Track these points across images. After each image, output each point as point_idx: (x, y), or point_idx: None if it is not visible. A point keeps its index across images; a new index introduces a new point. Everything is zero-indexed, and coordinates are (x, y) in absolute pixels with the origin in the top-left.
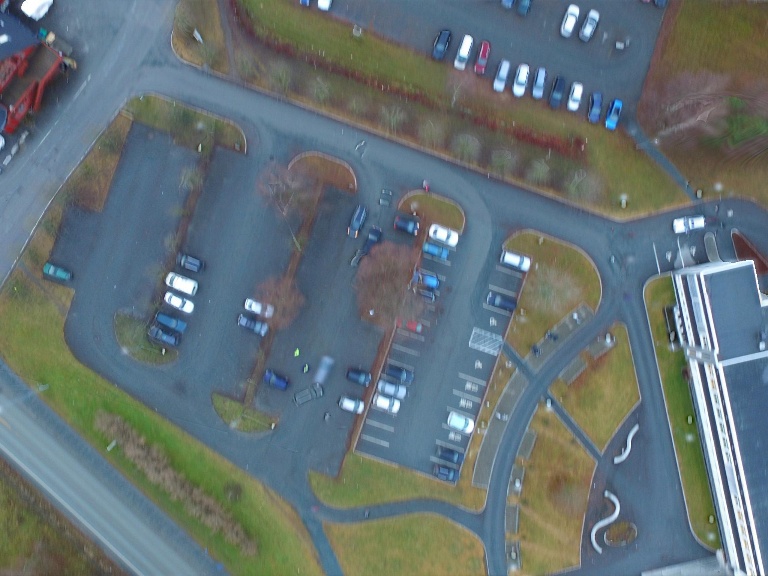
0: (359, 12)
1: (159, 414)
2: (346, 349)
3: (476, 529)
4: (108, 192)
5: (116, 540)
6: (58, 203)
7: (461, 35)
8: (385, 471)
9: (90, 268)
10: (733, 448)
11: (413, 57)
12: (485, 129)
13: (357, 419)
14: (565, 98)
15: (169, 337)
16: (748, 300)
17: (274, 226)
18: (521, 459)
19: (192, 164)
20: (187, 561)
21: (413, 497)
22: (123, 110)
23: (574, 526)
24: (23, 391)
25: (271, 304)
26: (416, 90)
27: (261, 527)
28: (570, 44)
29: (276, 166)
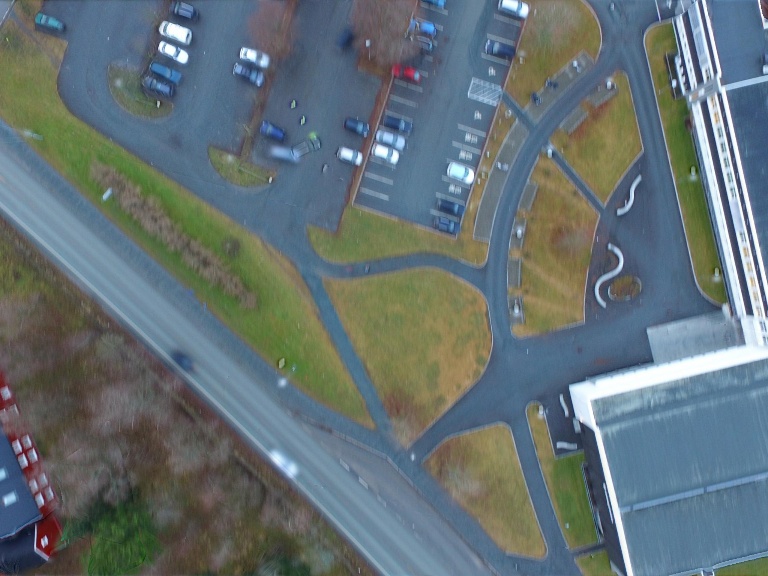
0: None
1: (155, 168)
2: (343, 100)
3: (478, 283)
4: None
5: (113, 295)
6: None
7: None
8: (385, 225)
9: (82, 19)
10: (738, 175)
11: None
12: None
13: (355, 172)
14: None
15: (164, 86)
16: (751, 23)
17: None
18: (522, 212)
19: None
20: (186, 316)
21: (414, 251)
22: None
23: (577, 280)
24: (17, 144)
25: (266, 53)
26: None
27: (260, 283)
28: None
29: None
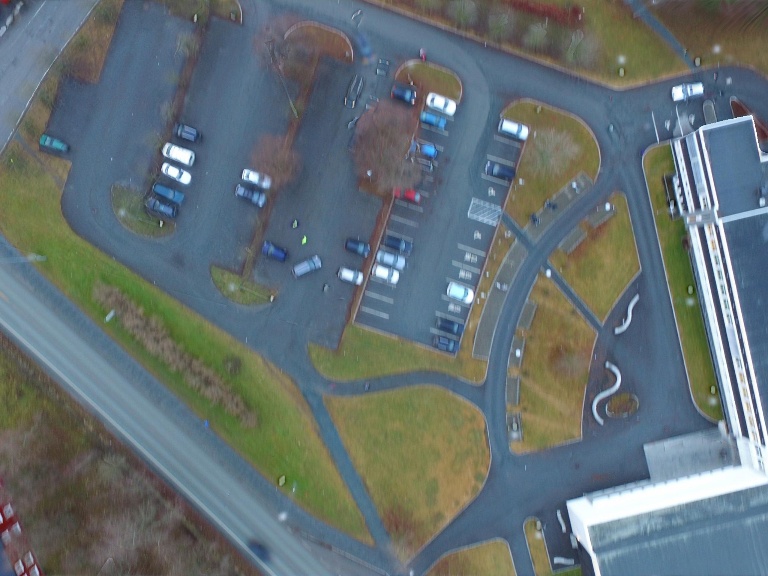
0: None
1: (157, 287)
2: (344, 220)
3: (477, 401)
4: (104, 63)
5: (116, 413)
6: (54, 74)
7: None
8: (385, 343)
9: (86, 140)
10: (734, 306)
11: None
12: None
13: (356, 291)
14: None
15: (166, 207)
16: (748, 156)
17: (271, 97)
18: (521, 330)
19: (188, 31)
20: (187, 434)
21: (413, 369)
22: None
23: (575, 398)
24: (21, 264)
25: (268, 175)
26: None
27: (261, 400)
28: None
29: (272, 36)
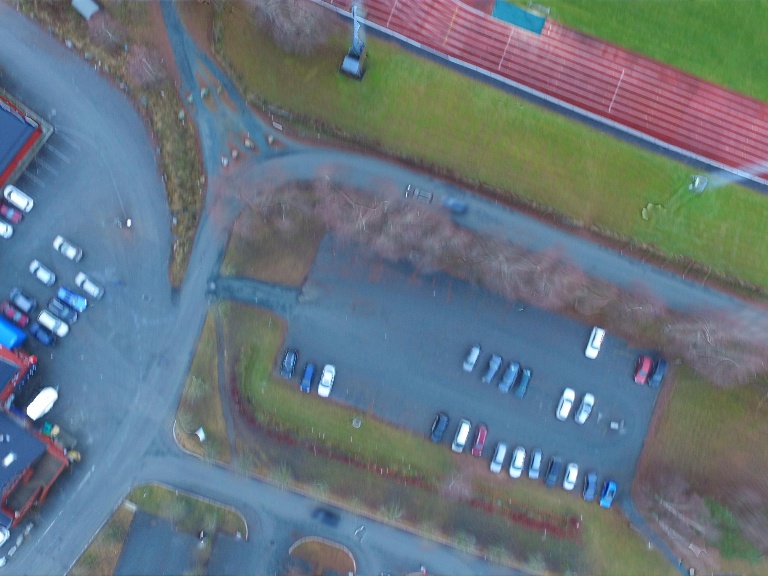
0: (358, 396)
1: None
2: None
3: None
4: None
5: None
6: None
7: (459, 419)
8: None
9: None
10: None
11: (411, 439)
12: (482, 511)
13: None
14: (560, 479)
15: None
16: None
17: None
18: None
19: (194, 562)
20: None
21: None
22: (126, 500)
23: None
24: None
25: None
26: (414, 472)
27: None
28: (565, 426)
29: (277, 551)
